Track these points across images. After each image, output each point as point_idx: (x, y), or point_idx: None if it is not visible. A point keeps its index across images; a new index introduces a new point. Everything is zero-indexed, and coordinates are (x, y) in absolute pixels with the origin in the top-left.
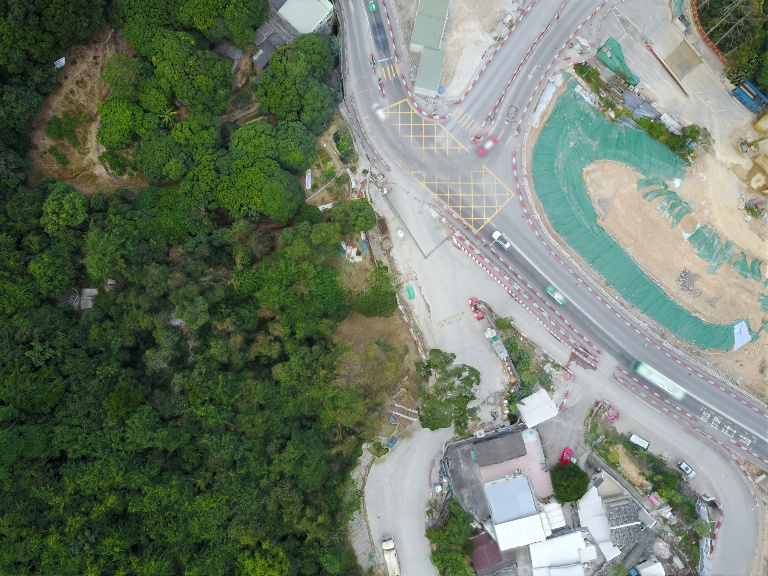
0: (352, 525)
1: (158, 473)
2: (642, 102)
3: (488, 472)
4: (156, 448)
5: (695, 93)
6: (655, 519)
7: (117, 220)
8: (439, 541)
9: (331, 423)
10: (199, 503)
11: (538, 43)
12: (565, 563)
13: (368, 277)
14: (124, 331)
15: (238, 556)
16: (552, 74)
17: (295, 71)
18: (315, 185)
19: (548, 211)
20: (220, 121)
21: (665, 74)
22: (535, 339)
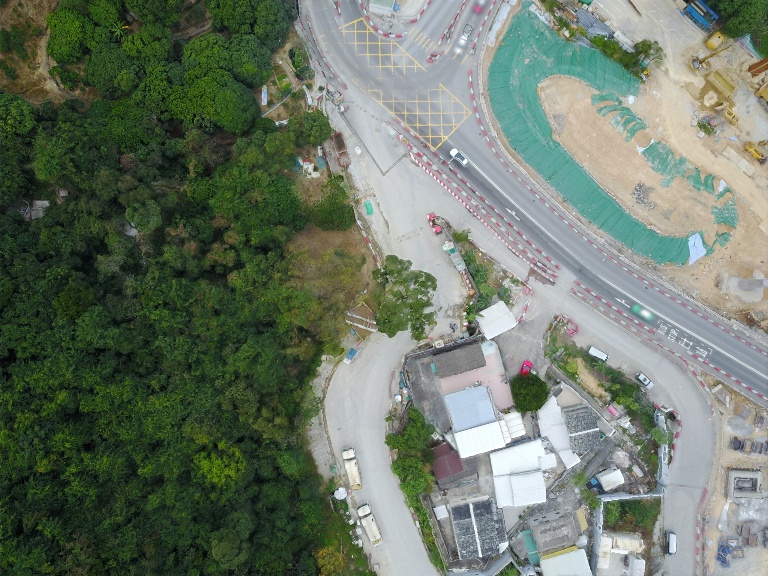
0: (312, 435)
1: (110, 374)
2: (596, 20)
3: (448, 385)
4: (108, 350)
5: (647, 12)
6: (614, 429)
7: (67, 126)
8: (398, 446)
9: (287, 327)
10: (152, 403)
11: None
12: (525, 470)
13: (324, 188)
14: (75, 236)
15: (194, 458)
16: None
17: None
18: (271, 101)
19: (505, 129)
20: (174, 38)
21: None
22: (494, 255)
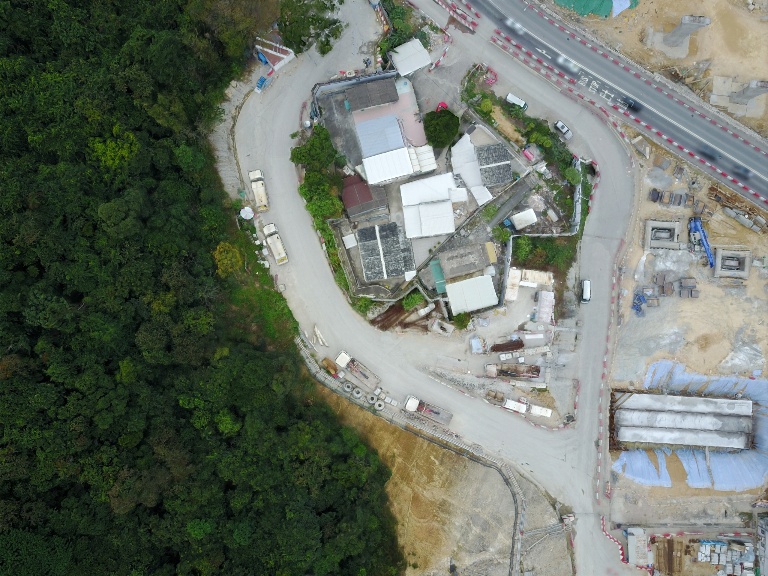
0: (219, 156)
1: (5, 53)
2: None
3: None
4: (3, 29)
5: None
6: (530, 174)
7: None
8: (301, 156)
9: (187, 26)
10: (45, 79)
11: None
12: (434, 200)
13: None
14: None
15: (89, 141)
16: None
17: None
18: None
19: None
20: None
21: None
22: (413, 1)
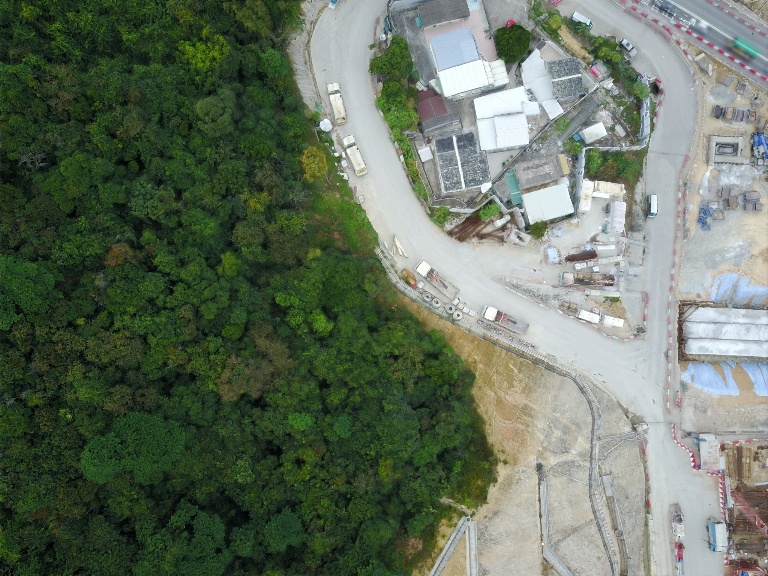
0: (297, 69)
1: None
2: None
3: None
4: None
5: None
6: None
7: None
8: (382, 65)
9: None
10: None
11: None
12: (508, 113)
13: None
14: None
15: (179, 44)
16: None
17: None
18: None
19: None
20: None
21: None
22: None
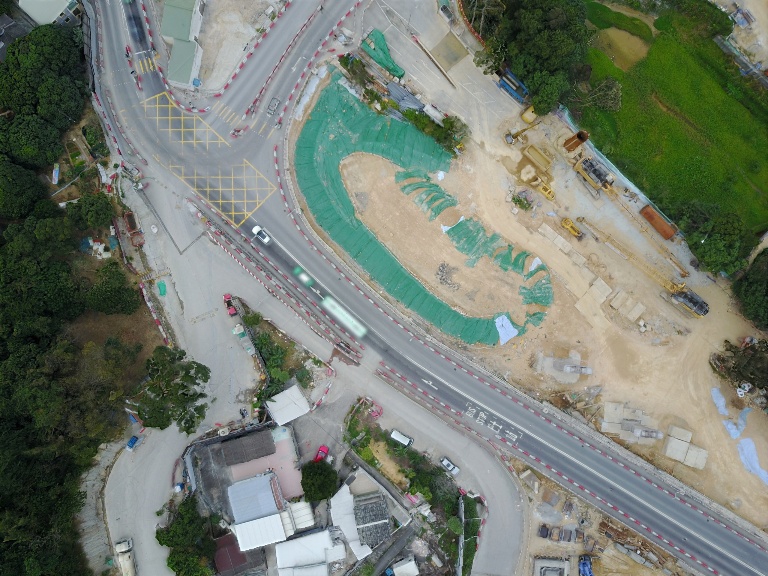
0: (85, 527)
1: None
2: (406, 94)
3: (239, 471)
4: None
5: (462, 84)
6: (414, 517)
7: None
8: (164, 542)
9: (42, 423)
10: None
11: (301, 35)
12: (310, 563)
13: None
14: None
15: None
16: (315, 66)
17: (26, 63)
18: (62, 180)
19: (311, 205)
20: None
21: (432, 65)
22: (295, 335)
